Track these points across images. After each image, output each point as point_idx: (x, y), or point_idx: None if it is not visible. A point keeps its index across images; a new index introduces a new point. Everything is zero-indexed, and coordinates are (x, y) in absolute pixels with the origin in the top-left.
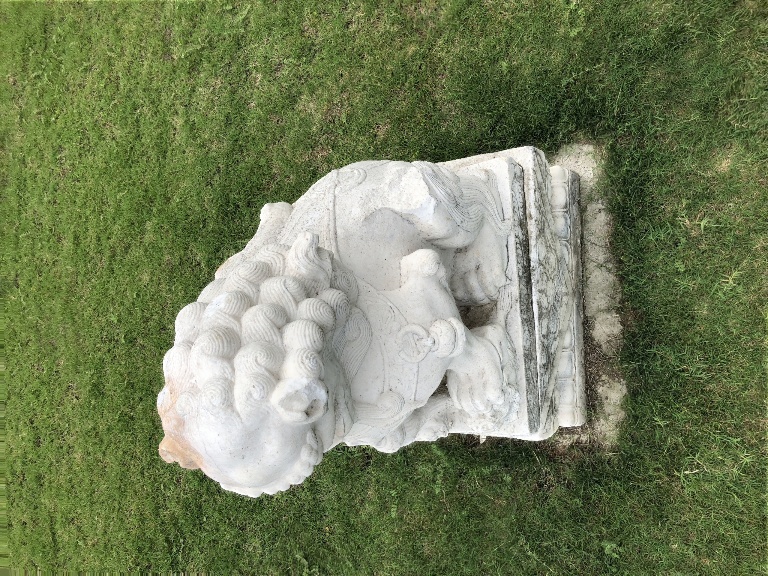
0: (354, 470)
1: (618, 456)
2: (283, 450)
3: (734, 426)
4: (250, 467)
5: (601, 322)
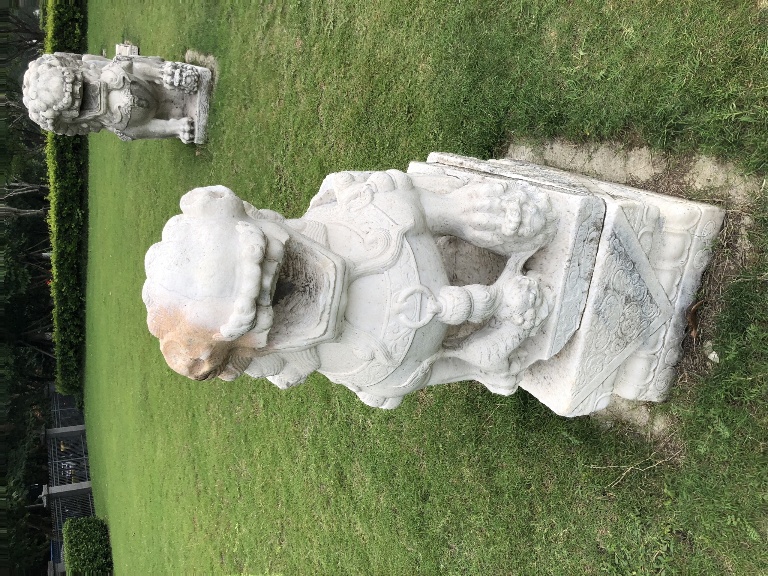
0: (691, 567)
1: (765, 175)
2: (213, 230)
3: (761, 32)
4: (200, 264)
5: (635, 168)
